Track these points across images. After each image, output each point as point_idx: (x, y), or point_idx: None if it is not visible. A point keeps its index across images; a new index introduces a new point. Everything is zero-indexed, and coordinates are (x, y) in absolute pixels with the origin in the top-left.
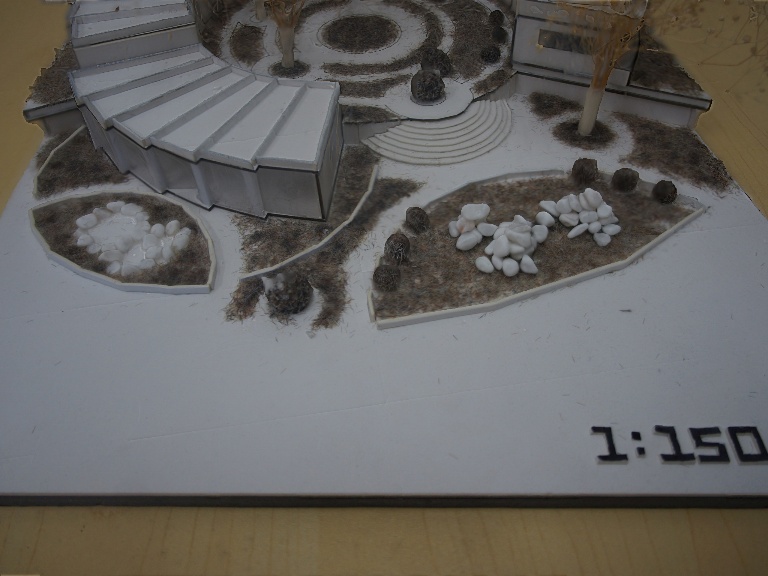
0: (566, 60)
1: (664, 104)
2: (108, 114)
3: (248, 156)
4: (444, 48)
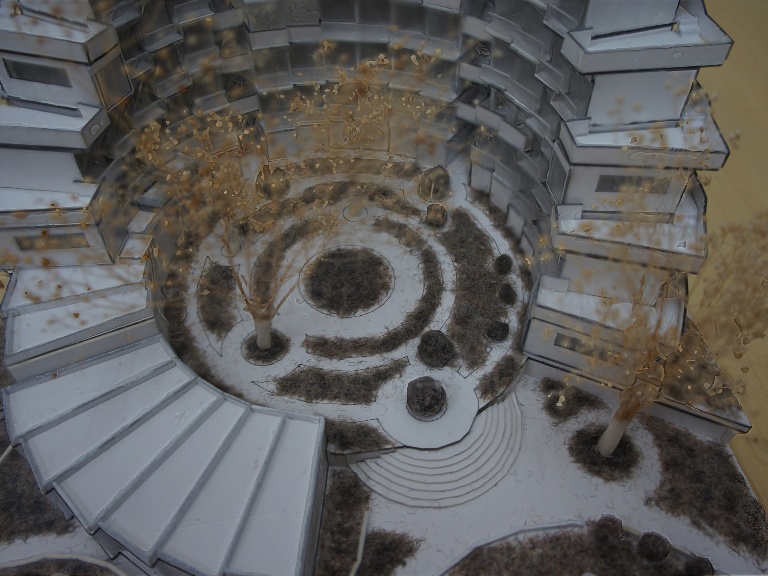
0: (586, 362)
1: (696, 418)
2: (48, 464)
3: (215, 558)
4: (444, 311)
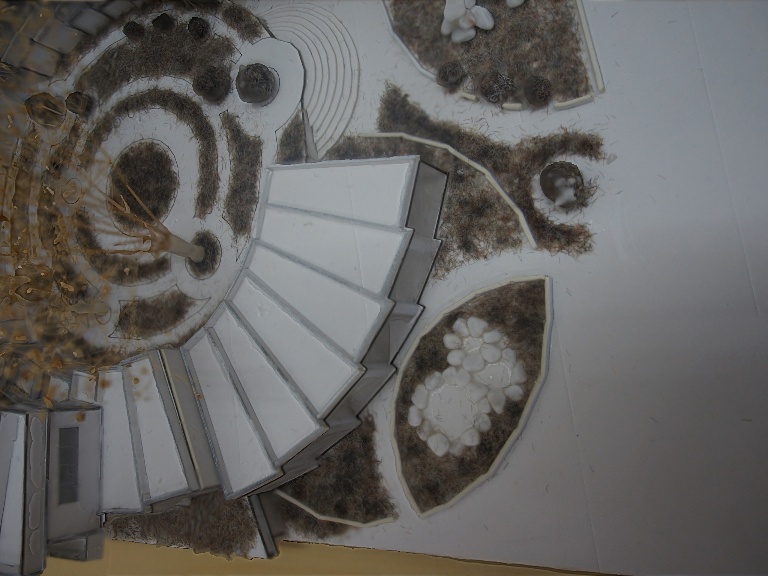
0: None
1: None
2: (302, 432)
3: (388, 243)
4: (177, 85)
